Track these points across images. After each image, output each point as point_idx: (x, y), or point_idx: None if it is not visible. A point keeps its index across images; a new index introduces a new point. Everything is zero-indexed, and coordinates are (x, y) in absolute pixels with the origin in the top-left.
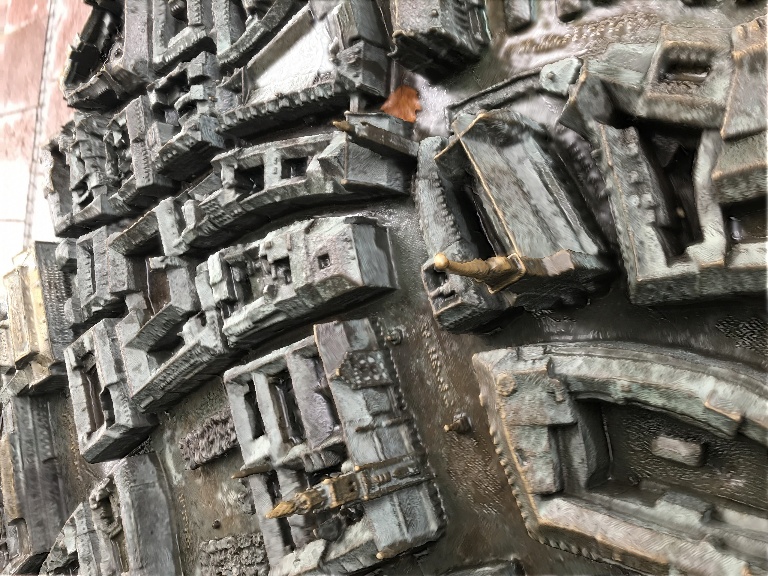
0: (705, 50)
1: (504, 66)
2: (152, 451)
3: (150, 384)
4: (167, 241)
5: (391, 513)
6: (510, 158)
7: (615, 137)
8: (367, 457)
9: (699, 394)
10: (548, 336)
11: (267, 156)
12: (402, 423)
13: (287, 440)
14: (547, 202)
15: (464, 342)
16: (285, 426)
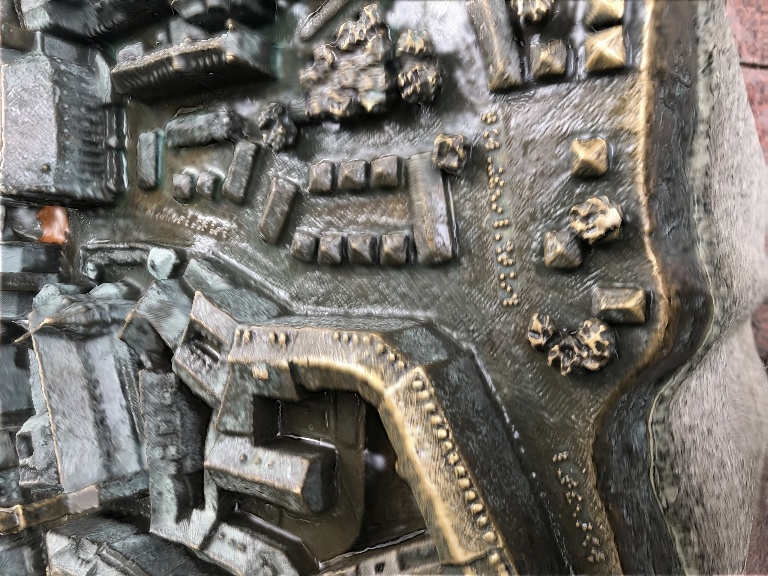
0: (216, 338)
1: (135, 221)
2: None
3: None
4: None
5: None
6: (92, 352)
7: (153, 384)
8: None
9: None
10: (139, 506)
11: None
12: (25, 544)
13: None
14: (118, 406)
15: None
16: None
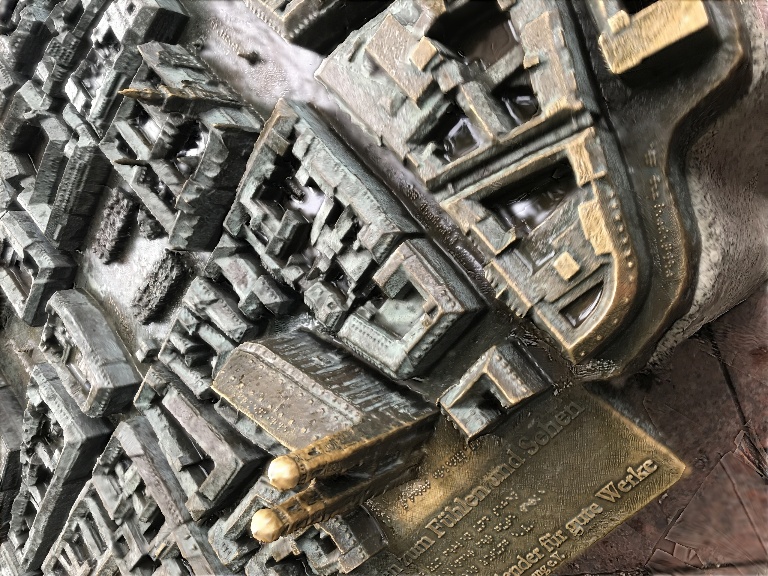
0: None
1: None
2: (79, 288)
3: (54, 210)
4: (34, 105)
5: (221, 117)
6: None
7: None
8: None
9: None
10: None
11: None
12: (218, 83)
13: None
14: None
15: (236, 11)
16: (149, 144)
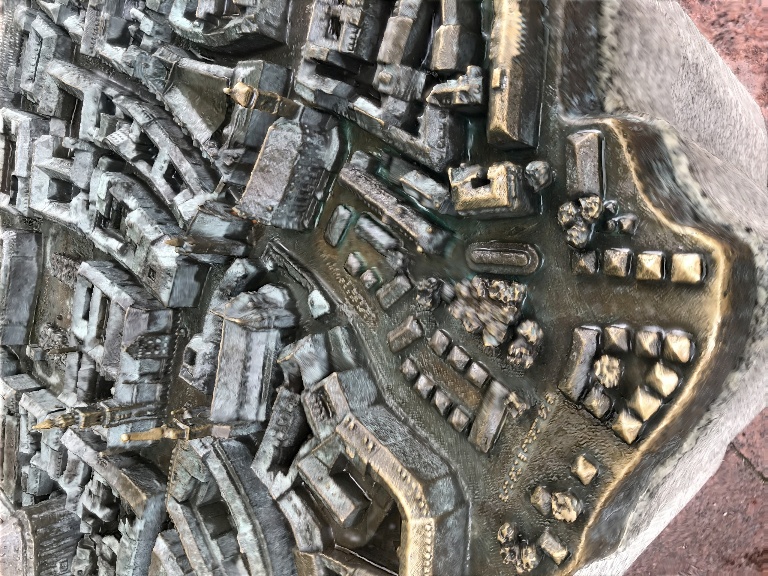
0: None
1: (311, 253)
2: (40, 232)
3: (41, 212)
4: (84, 124)
5: (124, 431)
6: (254, 339)
7: (286, 396)
8: (124, 397)
9: (240, 529)
10: None
11: (160, 154)
12: (160, 383)
13: (99, 336)
14: (257, 378)
15: None
16: (102, 327)
